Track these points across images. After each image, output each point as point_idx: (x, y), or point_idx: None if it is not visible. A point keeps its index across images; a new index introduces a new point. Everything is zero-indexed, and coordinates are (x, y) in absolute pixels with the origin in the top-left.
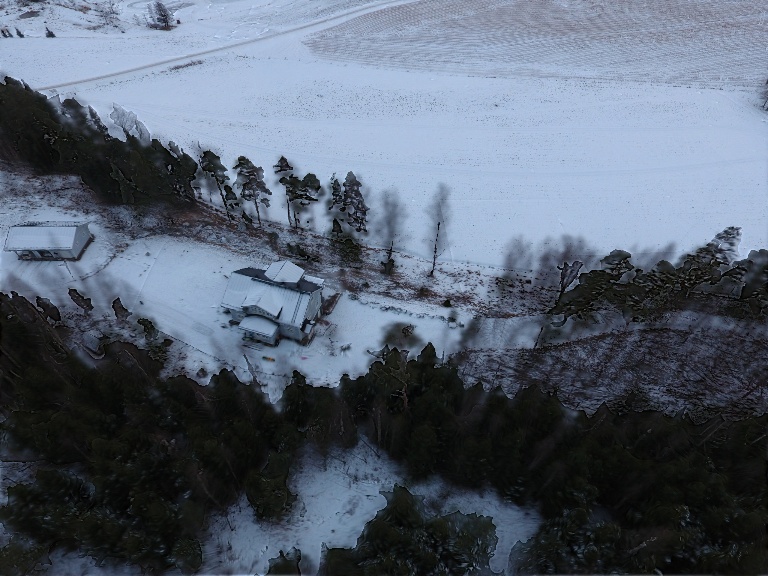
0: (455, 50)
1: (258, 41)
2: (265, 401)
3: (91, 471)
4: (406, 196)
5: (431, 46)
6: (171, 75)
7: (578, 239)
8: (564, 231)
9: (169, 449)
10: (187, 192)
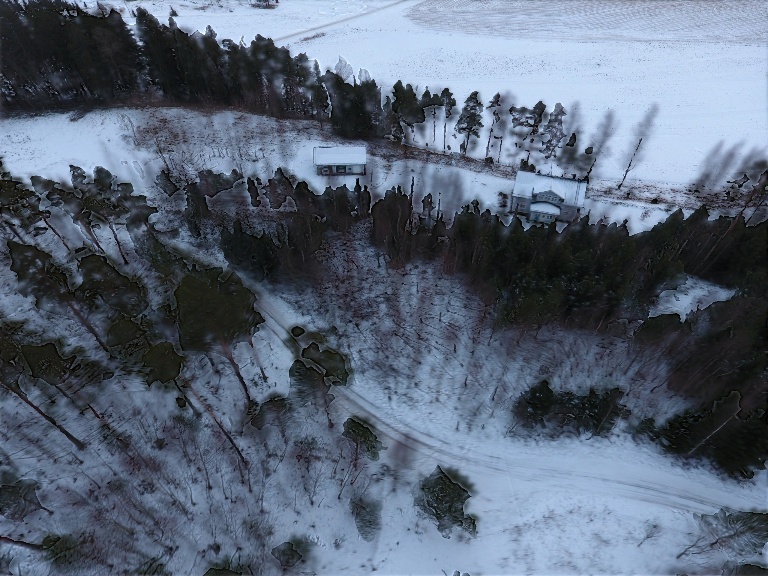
0: (541, 20)
1: (364, 15)
2: None
3: (505, 288)
4: None
5: (519, 17)
6: (304, 46)
7: (719, 162)
8: (704, 157)
9: (599, 252)
10: (397, 131)
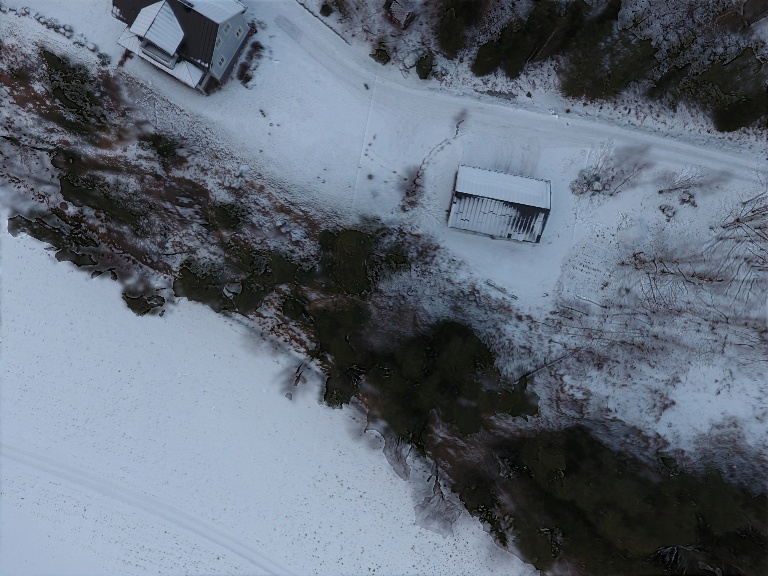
0: None
1: None
2: None
3: None
4: (8, 354)
5: None
6: None
7: None
8: None
9: None
10: None
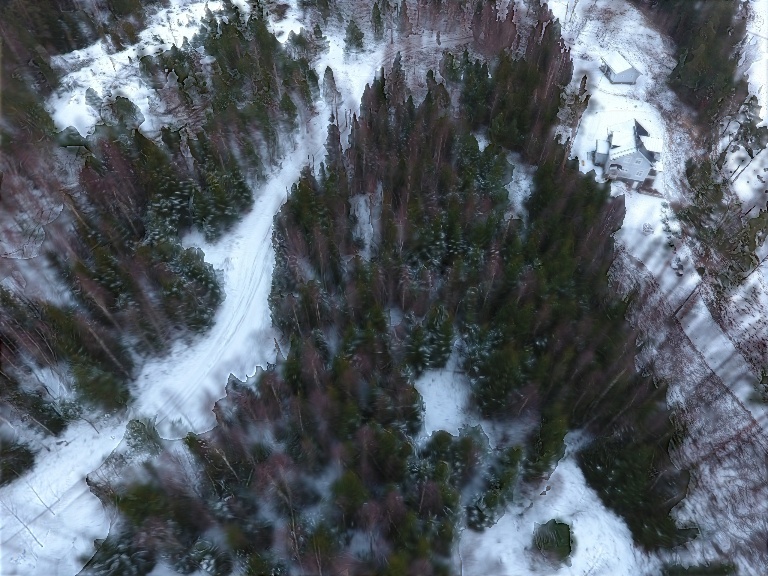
0: None
1: None
2: (547, 137)
3: None
4: None
5: None
6: None
7: None
8: None
9: (507, 93)
10: None
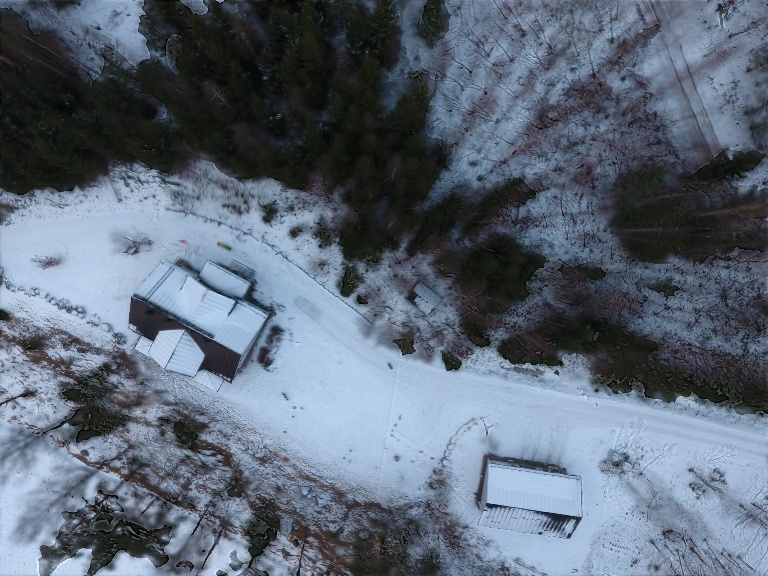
0: None
1: None
2: None
3: None
4: None
5: None
6: None
7: None
8: None
9: (247, 40)
10: None
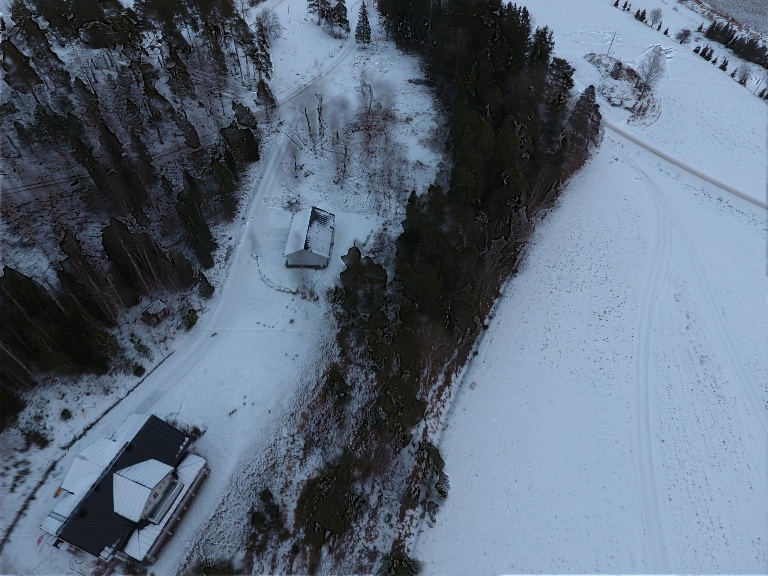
0: None
1: None
2: None
3: None
4: None
5: None
6: None
7: None
8: None
9: None
10: None
